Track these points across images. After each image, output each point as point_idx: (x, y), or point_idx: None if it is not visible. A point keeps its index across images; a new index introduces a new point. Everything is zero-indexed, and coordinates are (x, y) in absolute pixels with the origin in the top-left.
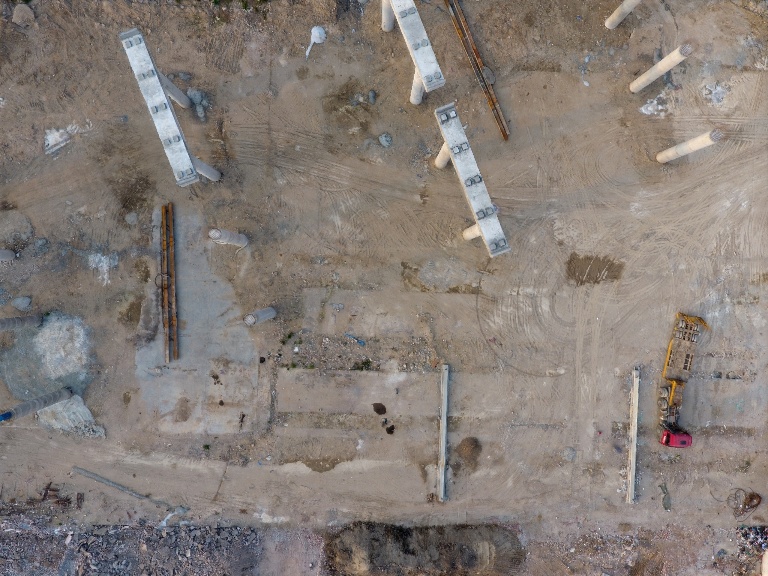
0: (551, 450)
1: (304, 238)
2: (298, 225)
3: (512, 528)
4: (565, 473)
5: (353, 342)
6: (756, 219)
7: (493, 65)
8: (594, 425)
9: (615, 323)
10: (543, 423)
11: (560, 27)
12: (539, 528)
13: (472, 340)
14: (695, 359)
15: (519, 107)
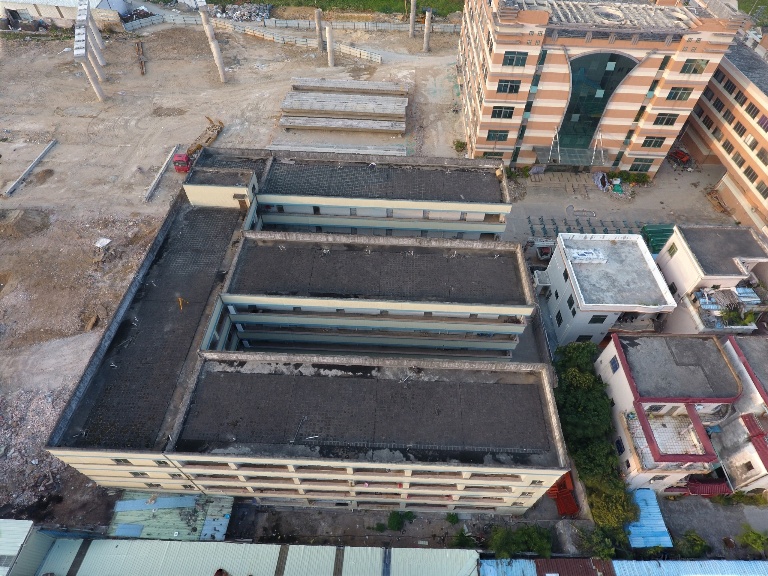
0: (101, 176)
1: (8, 99)
2: (8, 95)
3: (48, 212)
4: (105, 188)
5: (3, 131)
6: (272, 99)
7: (149, 58)
8: (138, 167)
9: (173, 129)
10: (103, 165)
11: (188, 50)
12: (69, 213)
13: (79, 133)
14: (218, 143)
15: (156, 68)
